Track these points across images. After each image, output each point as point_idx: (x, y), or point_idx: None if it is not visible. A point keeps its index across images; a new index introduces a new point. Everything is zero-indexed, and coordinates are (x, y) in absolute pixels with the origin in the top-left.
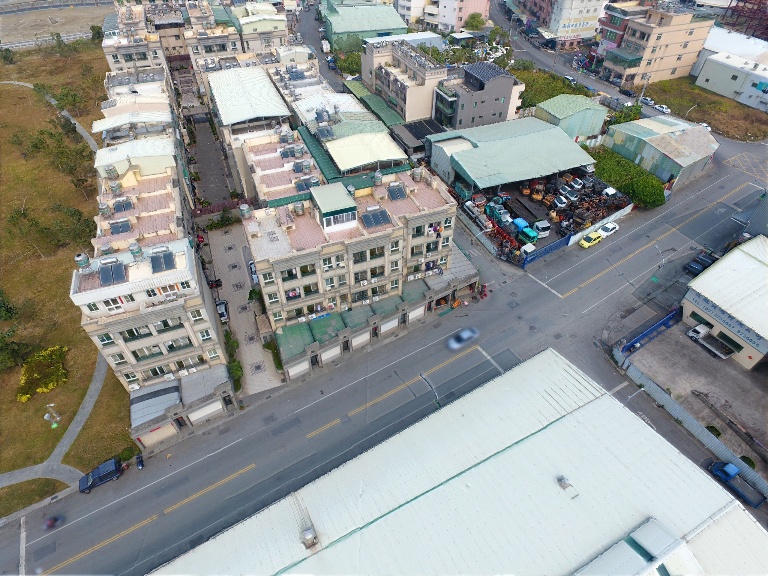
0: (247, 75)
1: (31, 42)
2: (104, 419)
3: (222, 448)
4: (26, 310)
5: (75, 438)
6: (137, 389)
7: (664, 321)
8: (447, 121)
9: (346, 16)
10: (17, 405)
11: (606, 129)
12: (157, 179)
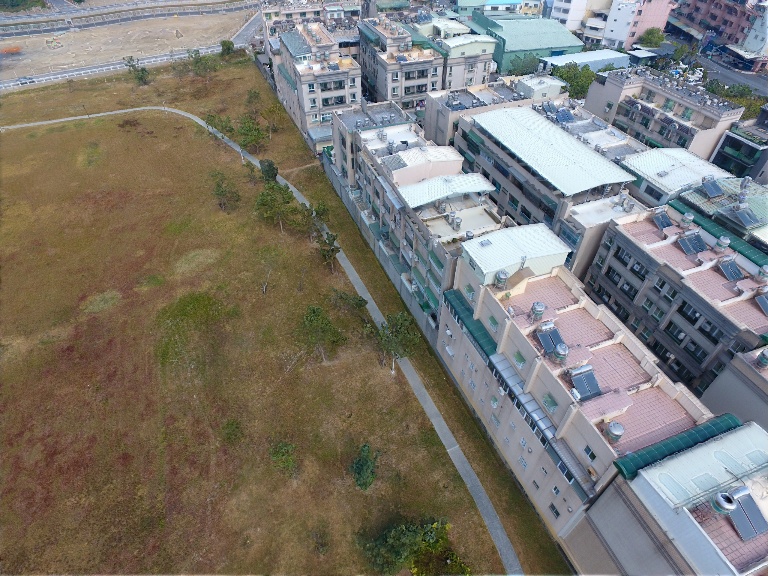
0: (526, 119)
1: (157, 58)
2: None
3: None
4: (348, 449)
5: None
6: None
7: None
8: (735, 171)
9: (511, 31)
10: None
11: None
12: (542, 283)
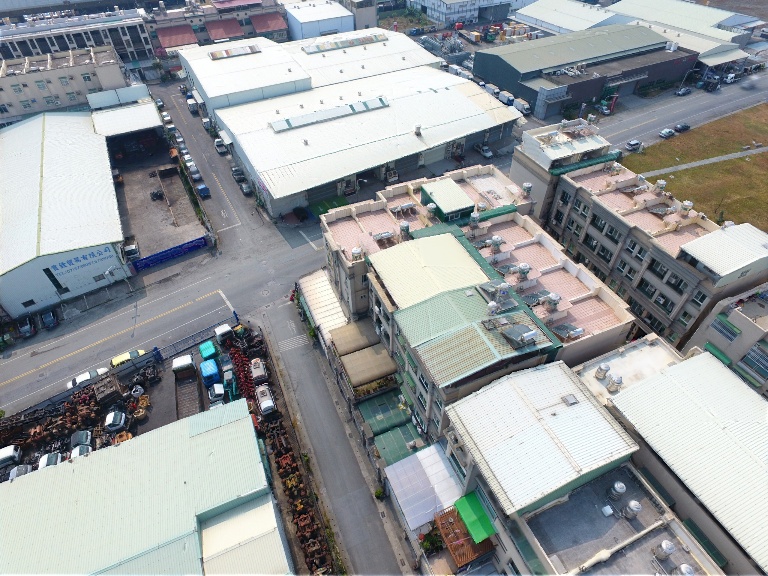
0: None
1: None
2: None
3: None
4: None
5: None
6: None
7: (145, 270)
8: None
9: None
10: None
11: None
12: None
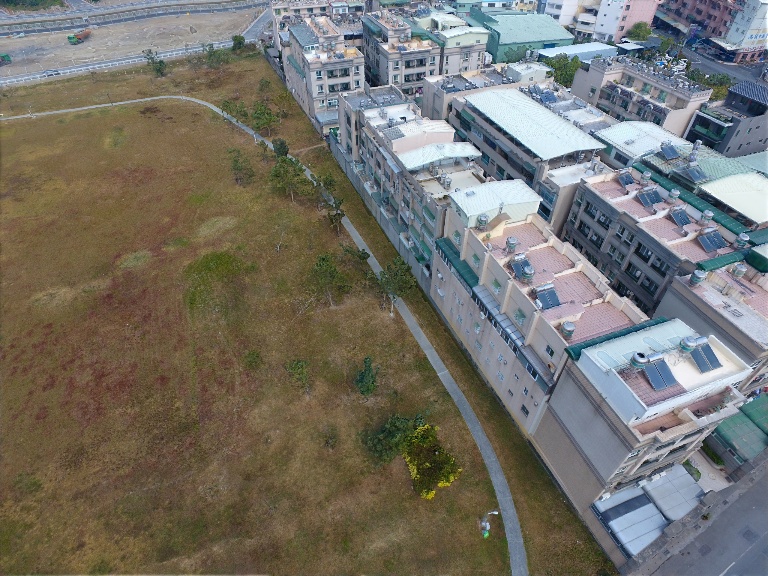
0: (512, 98)
1: (172, 52)
2: (539, 526)
3: (719, 575)
4: (352, 373)
5: (526, 554)
6: (607, 499)
7: None
8: None
9: (506, 26)
10: (421, 503)
11: None
12: (518, 228)
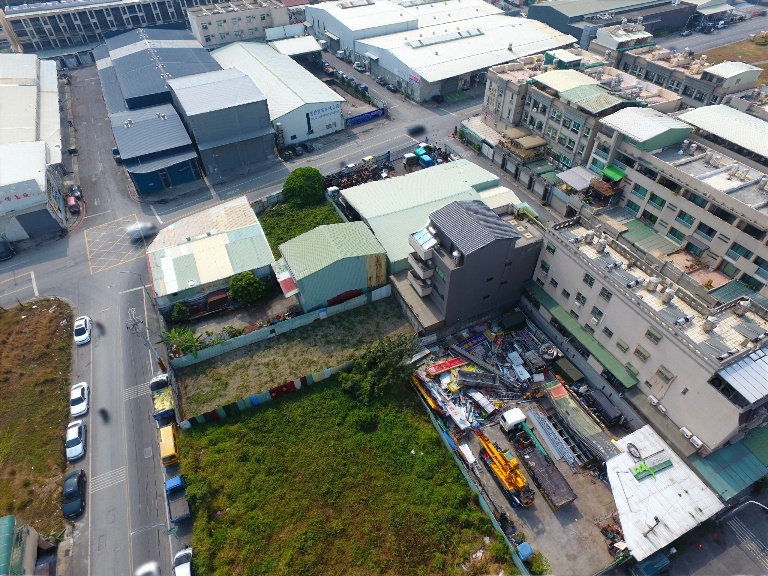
0: None
1: None
2: None
3: None
4: None
5: None
6: None
7: None
8: None
9: None
10: None
11: (249, 322)
12: None
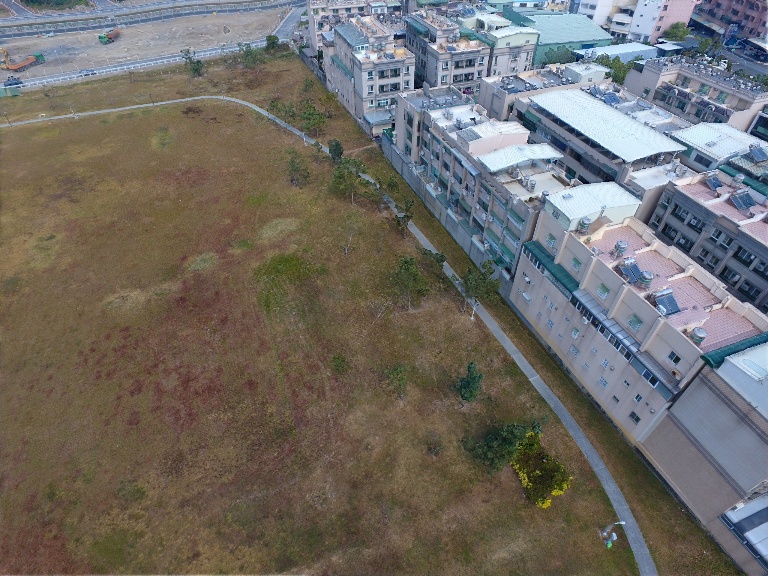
0: (580, 99)
1: (206, 52)
2: (661, 536)
3: None
4: (442, 378)
5: (655, 565)
6: (739, 509)
7: None
8: None
9: (543, 26)
10: (537, 512)
11: None
12: (615, 231)
